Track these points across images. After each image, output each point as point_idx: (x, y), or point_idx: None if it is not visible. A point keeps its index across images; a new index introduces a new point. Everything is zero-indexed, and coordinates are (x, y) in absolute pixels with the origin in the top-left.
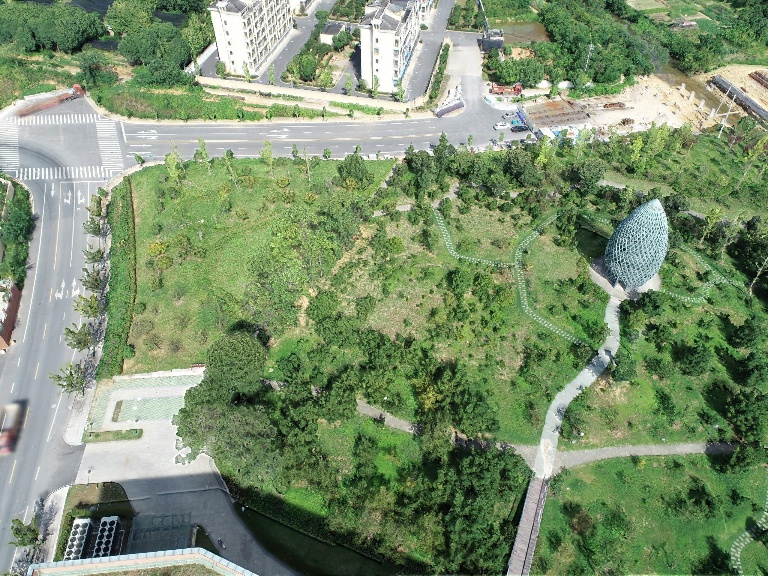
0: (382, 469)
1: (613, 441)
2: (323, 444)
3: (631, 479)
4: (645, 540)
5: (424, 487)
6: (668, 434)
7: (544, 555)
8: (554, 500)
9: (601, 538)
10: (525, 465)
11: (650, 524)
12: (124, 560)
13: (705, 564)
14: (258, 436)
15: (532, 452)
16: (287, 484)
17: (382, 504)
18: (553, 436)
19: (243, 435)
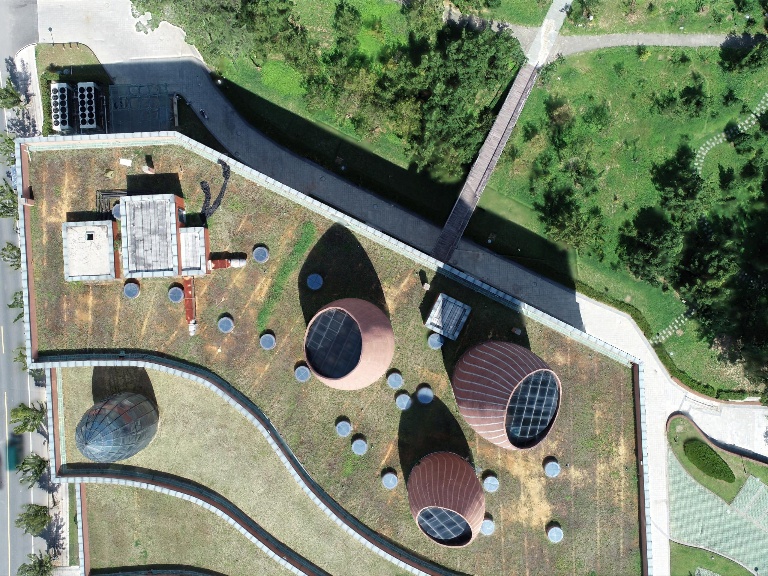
0: (365, 45)
1: (624, 26)
2: (301, 11)
3: (628, 72)
4: (620, 135)
5: (406, 70)
6: (689, 22)
7: (517, 143)
8: (541, 90)
9: (577, 130)
10: (519, 50)
11: (631, 119)
12: (104, 139)
13: (669, 160)
14: (220, 8)
15: (531, 35)
16: (263, 58)
17: (361, 87)
18: (559, 16)
19: (201, 10)
